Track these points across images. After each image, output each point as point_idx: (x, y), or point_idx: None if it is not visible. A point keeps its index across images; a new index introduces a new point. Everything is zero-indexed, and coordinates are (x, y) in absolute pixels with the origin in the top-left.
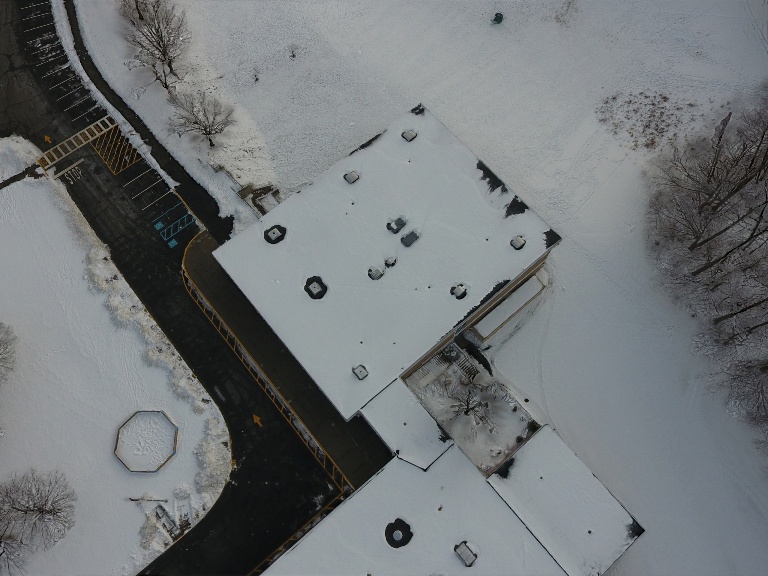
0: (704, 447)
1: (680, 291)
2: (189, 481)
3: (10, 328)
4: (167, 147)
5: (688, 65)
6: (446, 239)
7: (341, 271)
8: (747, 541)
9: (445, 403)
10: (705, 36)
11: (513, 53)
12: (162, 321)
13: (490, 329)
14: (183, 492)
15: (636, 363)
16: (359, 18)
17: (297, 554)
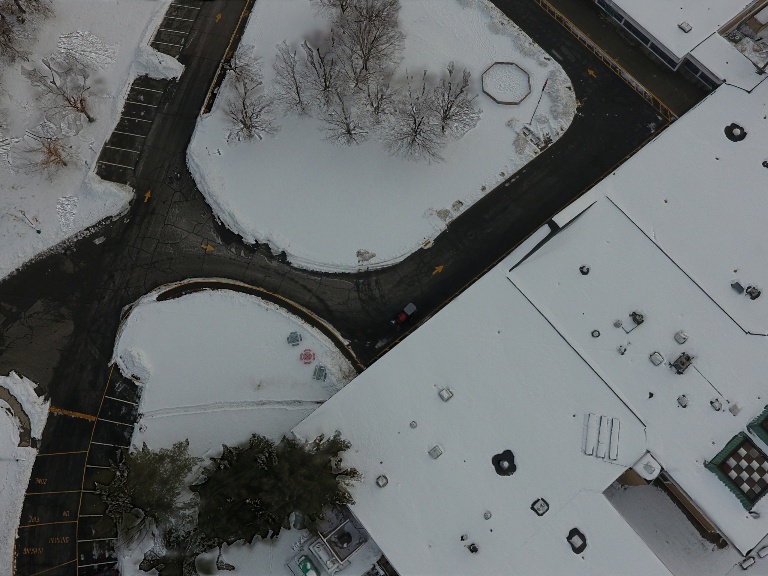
0: None
1: None
2: (546, 111)
3: None
4: None
5: None
6: None
7: None
8: None
9: None
10: None
11: None
12: (499, 4)
13: (767, 18)
14: (544, 117)
15: None
16: None
17: (658, 144)
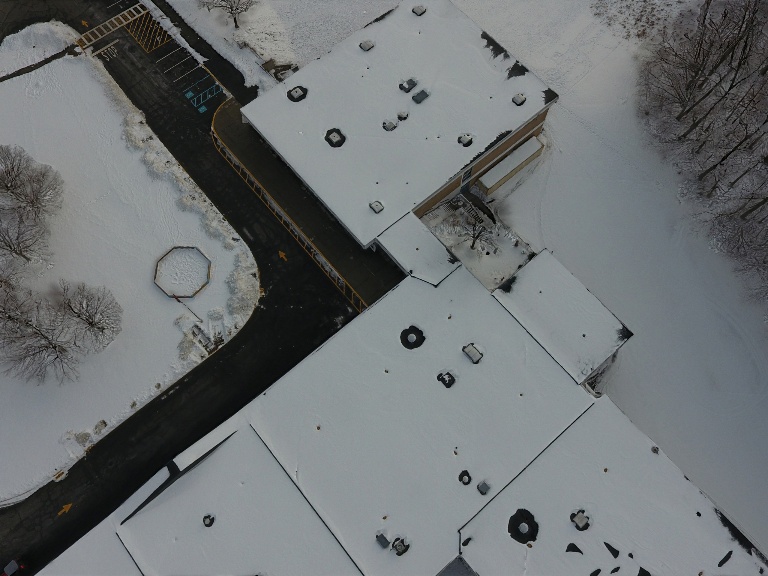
0: (689, 283)
1: (667, 147)
2: (222, 305)
3: (58, 173)
4: (195, 29)
5: None
6: (453, 97)
7: (358, 124)
8: (727, 360)
9: (453, 240)
10: None
11: None
12: (194, 174)
13: (494, 181)
14: (217, 313)
15: (627, 213)
16: None
17: (322, 354)
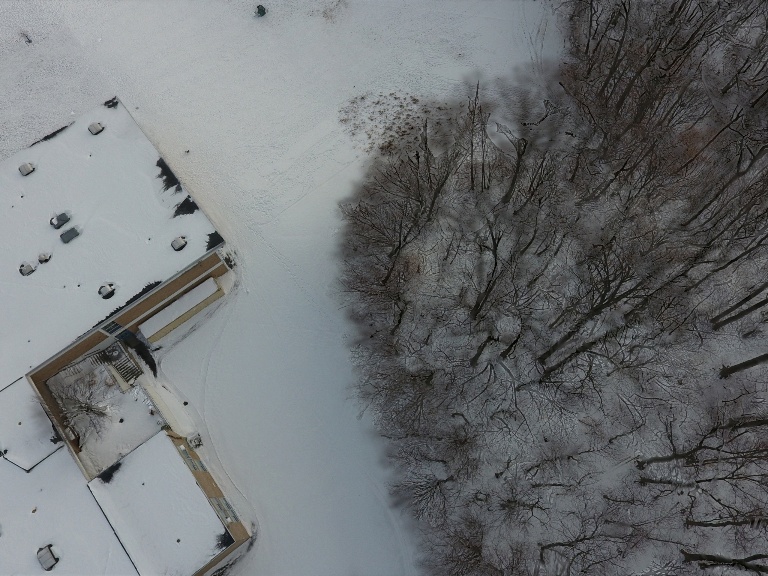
0: (354, 458)
1: None
2: None
3: None
4: None
5: (447, 67)
6: (107, 237)
7: None
8: (375, 555)
9: None
10: (471, 38)
11: (269, 47)
12: None
13: (154, 330)
14: None
15: (305, 370)
16: (111, 5)
17: None
